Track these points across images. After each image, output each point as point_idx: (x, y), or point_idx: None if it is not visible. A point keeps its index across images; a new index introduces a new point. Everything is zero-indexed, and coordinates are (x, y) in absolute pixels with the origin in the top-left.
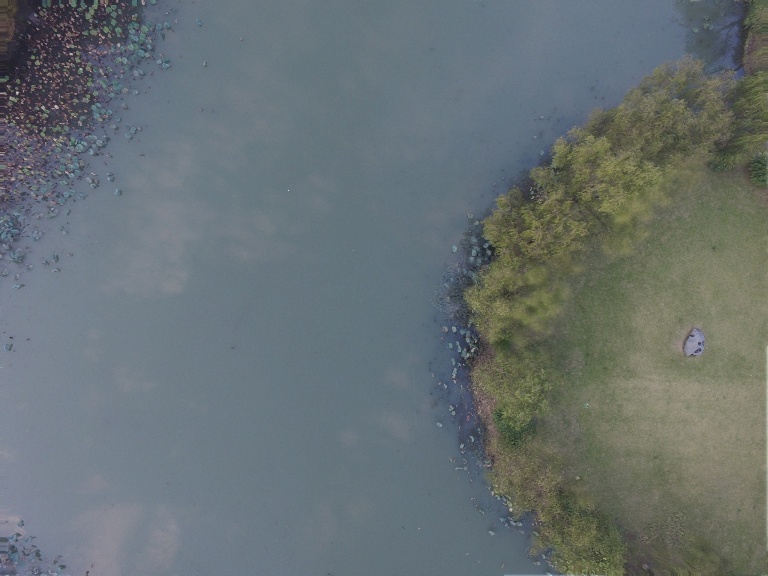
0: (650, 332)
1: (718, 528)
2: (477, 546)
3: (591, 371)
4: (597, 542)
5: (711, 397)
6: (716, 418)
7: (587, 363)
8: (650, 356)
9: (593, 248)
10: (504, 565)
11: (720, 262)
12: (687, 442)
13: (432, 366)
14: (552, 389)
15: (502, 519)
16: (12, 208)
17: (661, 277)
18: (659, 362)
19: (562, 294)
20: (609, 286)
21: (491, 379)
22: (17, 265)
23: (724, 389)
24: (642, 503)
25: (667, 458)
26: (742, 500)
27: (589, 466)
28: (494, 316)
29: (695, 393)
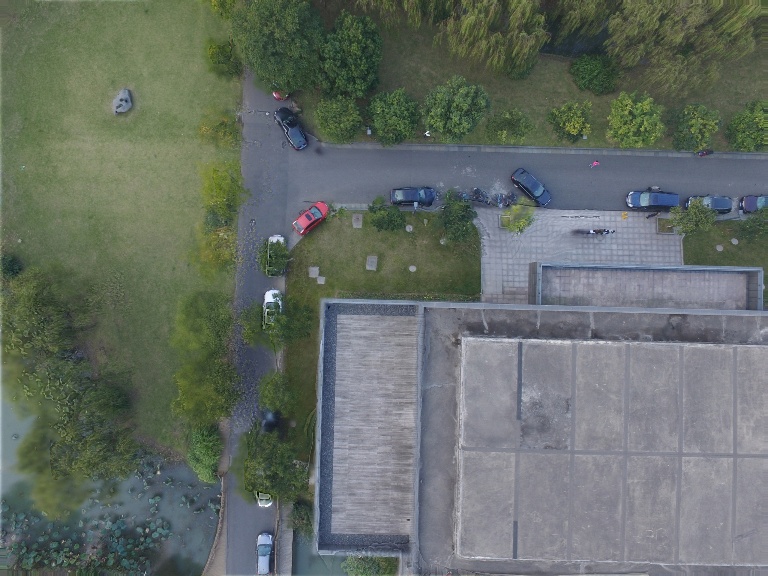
0: (83, 94)
1: (155, 287)
2: None
3: (28, 134)
4: (33, 301)
5: (143, 156)
6: (147, 177)
7: (24, 127)
8: (83, 117)
9: (35, 17)
10: None
11: (152, 24)
12: (121, 201)
13: None
14: None
15: None
16: None
17: (95, 41)
18: (92, 123)
19: (6, 63)
20: (47, 52)
21: None
22: None
23: (156, 148)
24: (82, 264)
25: (101, 218)
26: (176, 258)
27: (29, 228)
28: None
29: (127, 152)
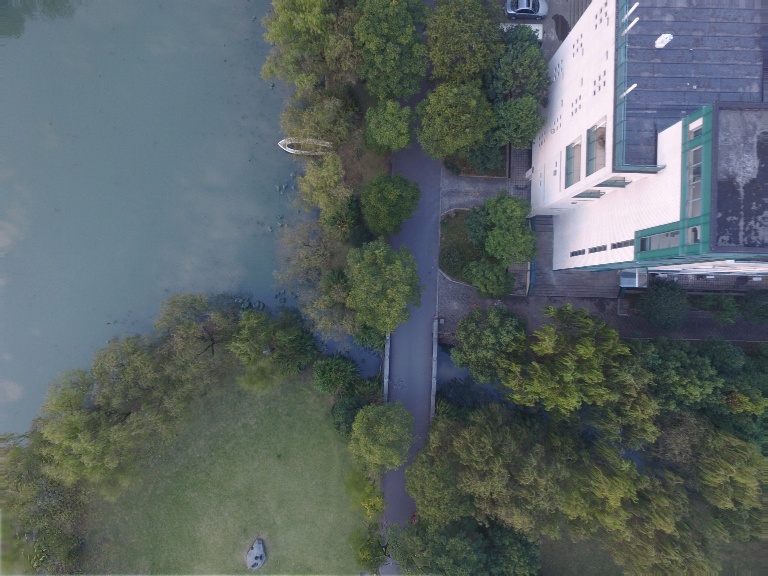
0: (214, 542)
1: None
2: None
3: None
4: None
5: None
6: None
7: (153, 573)
8: (214, 567)
9: (161, 455)
10: None
11: (285, 471)
12: None
13: (9, 571)
14: None
15: None
16: None
17: (225, 486)
18: (223, 573)
19: (131, 501)
20: (174, 495)
21: None
22: None
23: None
24: None
25: None
26: None
27: None
28: (67, 522)
29: None
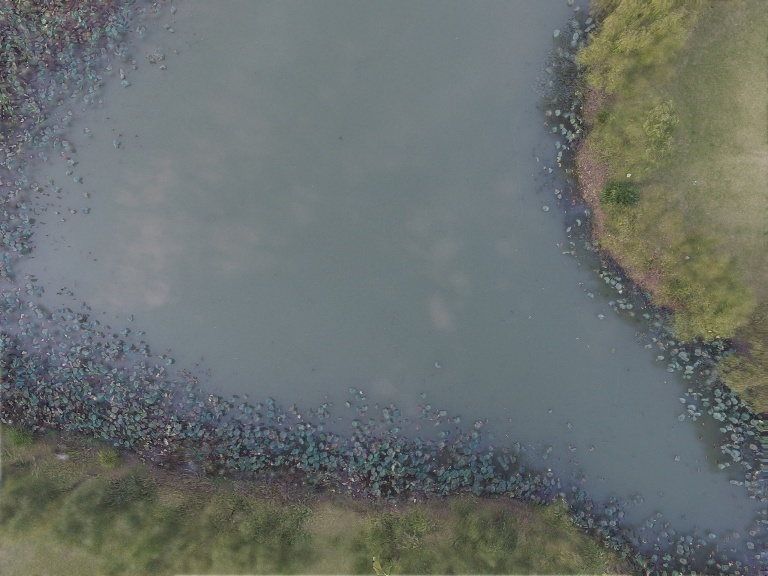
0: (756, 108)
1: None
2: (586, 331)
3: (698, 148)
4: (710, 320)
5: None
6: None
7: (693, 141)
8: (757, 131)
9: (695, 28)
10: (614, 349)
11: None
12: None
13: (536, 152)
14: (659, 168)
15: (611, 302)
16: (116, 2)
17: (765, 53)
18: (766, 137)
19: (665, 75)
20: (713, 64)
21: (596, 162)
22: (121, 60)
23: None
24: (753, 281)
25: None
26: None
27: (699, 245)
28: (597, 100)
29: None
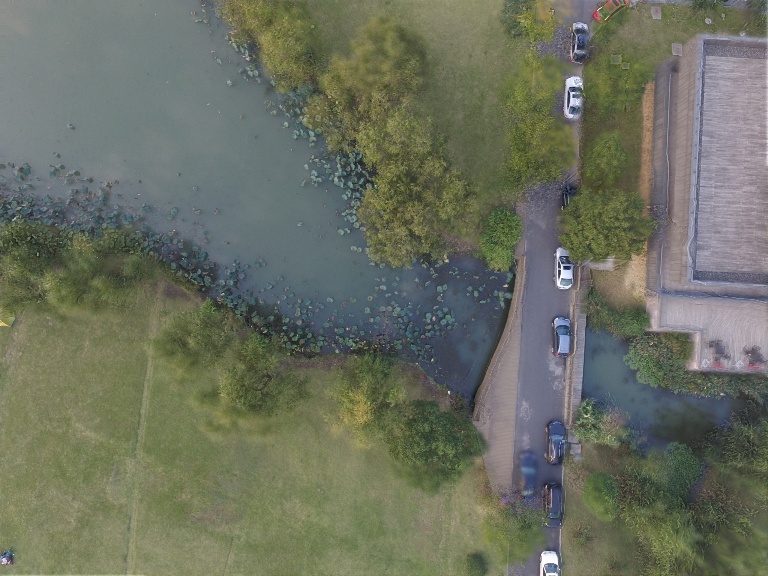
0: None
1: (450, 75)
2: (216, 98)
3: None
4: (329, 85)
5: None
6: None
7: None
8: None
9: None
10: (242, 115)
11: None
12: None
13: None
14: None
15: (240, 70)
16: None
17: None
18: None
19: None
20: None
21: None
22: None
23: None
24: (376, 51)
25: (399, 3)
26: (473, 46)
27: (323, 13)
28: None
29: None
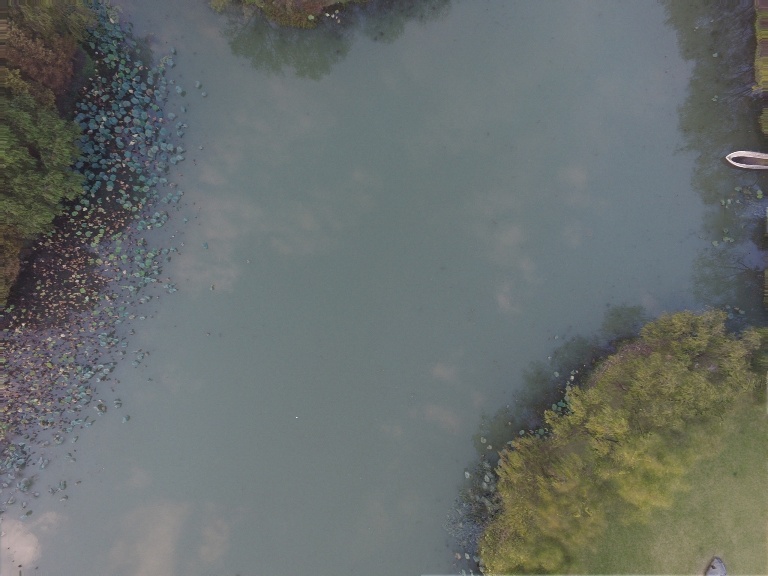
0: (669, 561)
1: None
2: None
3: None
4: None
5: None
6: None
7: None
8: None
9: (609, 473)
10: None
11: (741, 489)
12: None
13: None
14: None
15: None
16: (17, 438)
17: (680, 504)
18: None
19: (578, 520)
20: (626, 513)
21: None
22: (23, 493)
23: None
24: None
25: None
26: None
27: None
28: (508, 541)
29: None
